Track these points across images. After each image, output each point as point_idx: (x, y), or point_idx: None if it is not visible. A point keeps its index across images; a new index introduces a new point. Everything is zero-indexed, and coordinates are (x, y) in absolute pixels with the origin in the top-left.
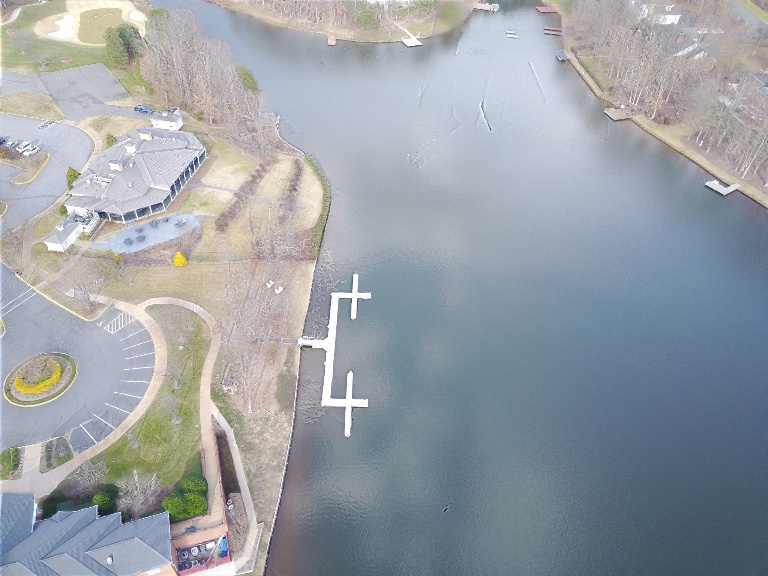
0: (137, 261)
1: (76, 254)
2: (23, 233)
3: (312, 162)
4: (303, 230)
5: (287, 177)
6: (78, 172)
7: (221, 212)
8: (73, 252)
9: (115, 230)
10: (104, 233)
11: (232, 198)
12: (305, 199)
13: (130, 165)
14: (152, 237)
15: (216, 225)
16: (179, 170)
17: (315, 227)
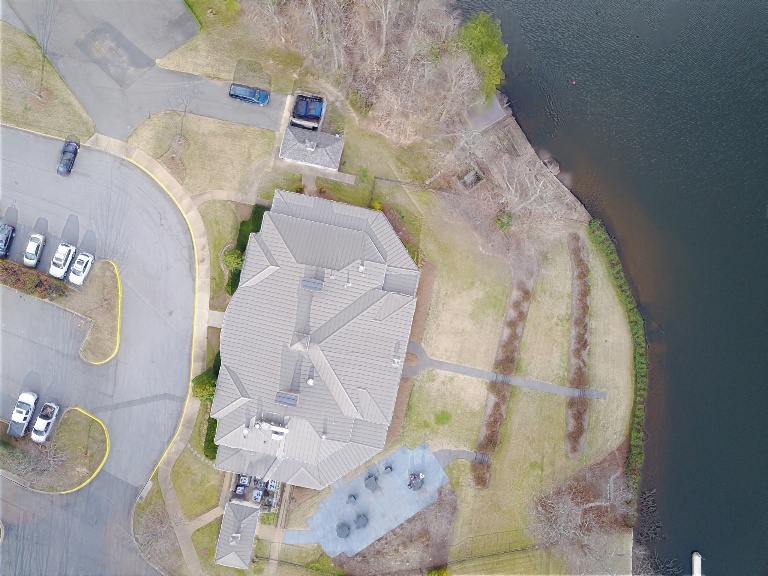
0: (370, 575)
1: (269, 558)
2: (163, 503)
3: (607, 248)
4: (608, 455)
5: (569, 310)
6: (190, 322)
7: (475, 439)
8: (262, 554)
9: (312, 498)
10: (296, 506)
11: (486, 397)
12: (604, 367)
13: (309, 383)
14: (377, 513)
15: (474, 477)
16: (394, 369)
17: (629, 450)
